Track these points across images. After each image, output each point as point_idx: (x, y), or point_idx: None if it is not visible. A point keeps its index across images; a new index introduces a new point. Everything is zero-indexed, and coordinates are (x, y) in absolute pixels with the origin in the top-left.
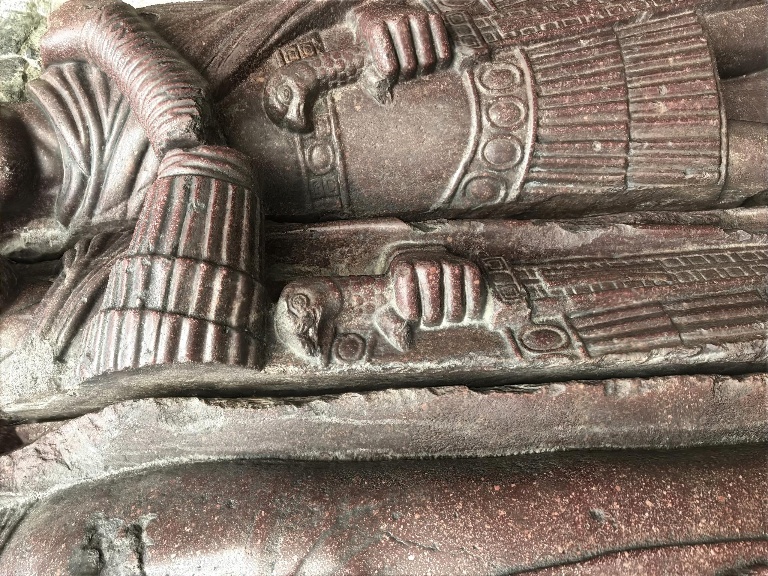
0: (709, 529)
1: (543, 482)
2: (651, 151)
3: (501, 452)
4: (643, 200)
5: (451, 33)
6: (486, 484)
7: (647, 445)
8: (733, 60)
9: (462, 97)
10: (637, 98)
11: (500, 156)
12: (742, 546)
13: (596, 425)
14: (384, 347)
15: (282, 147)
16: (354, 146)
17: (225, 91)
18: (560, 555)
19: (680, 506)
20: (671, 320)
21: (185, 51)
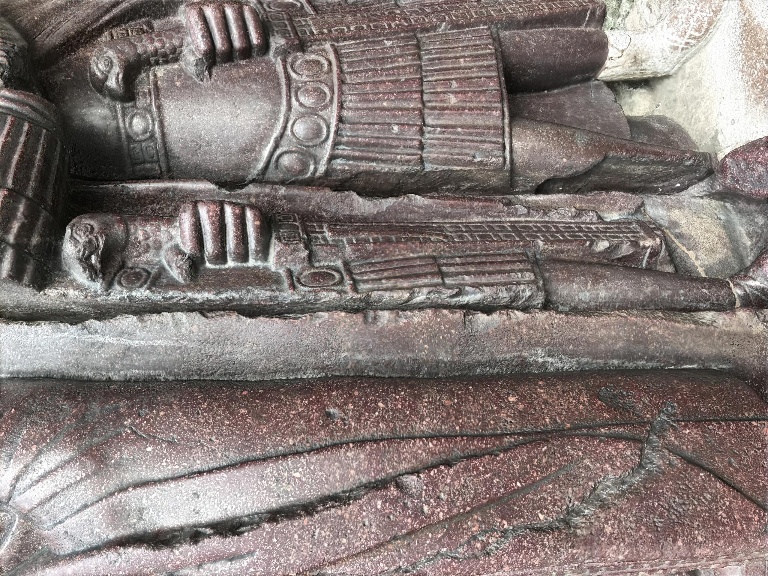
0: (431, 426)
1: (289, 389)
2: (443, 136)
3: (270, 377)
4: (443, 183)
5: (269, 27)
6: (236, 390)
7: (408, 375)
8: (528, 72)
9: (274, 80)
10: (431, 90)
11: (307, 133)
12: (458, 440)
13: (358, 353)
14: (167, 279)
15: (104, 114)
16: (172, 117)
17: (52, 60)
18: (290, 446)
19: (409, 407)
20: (440, 269)
21: (17, 23)
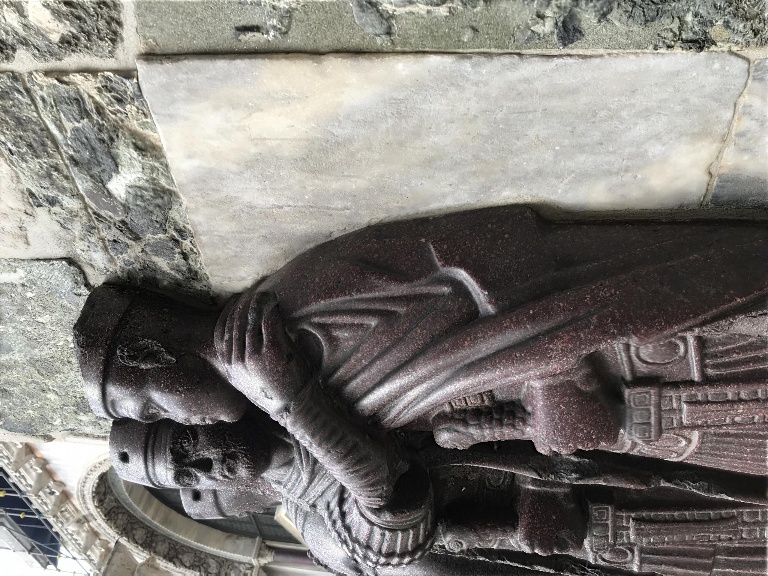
0: None
1: None
2: None
3: None
4: None
5: (627, 417)
6: None
7: None
8: None
9: (619, 442)
10: None
11: None
12: None
13: None
14: (509, 541)
15: None
16: None
17: None
18: None
19: None
20: (714, 558)
21: (360, 412)
